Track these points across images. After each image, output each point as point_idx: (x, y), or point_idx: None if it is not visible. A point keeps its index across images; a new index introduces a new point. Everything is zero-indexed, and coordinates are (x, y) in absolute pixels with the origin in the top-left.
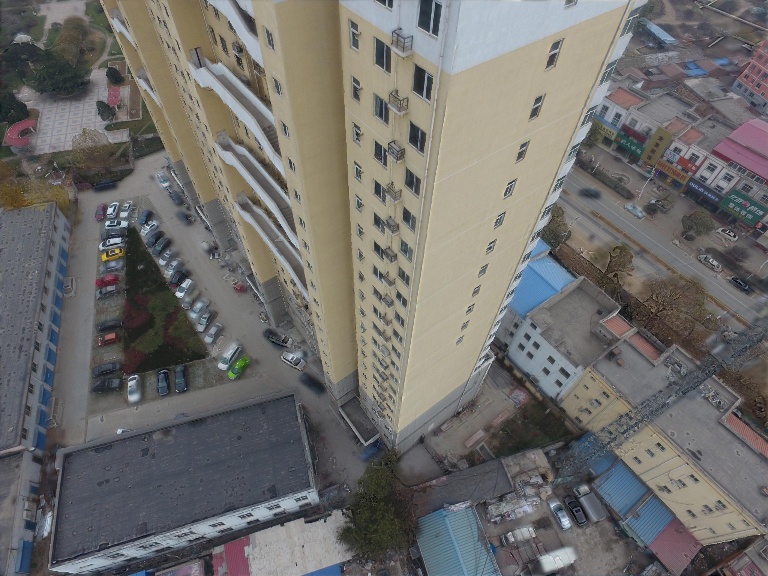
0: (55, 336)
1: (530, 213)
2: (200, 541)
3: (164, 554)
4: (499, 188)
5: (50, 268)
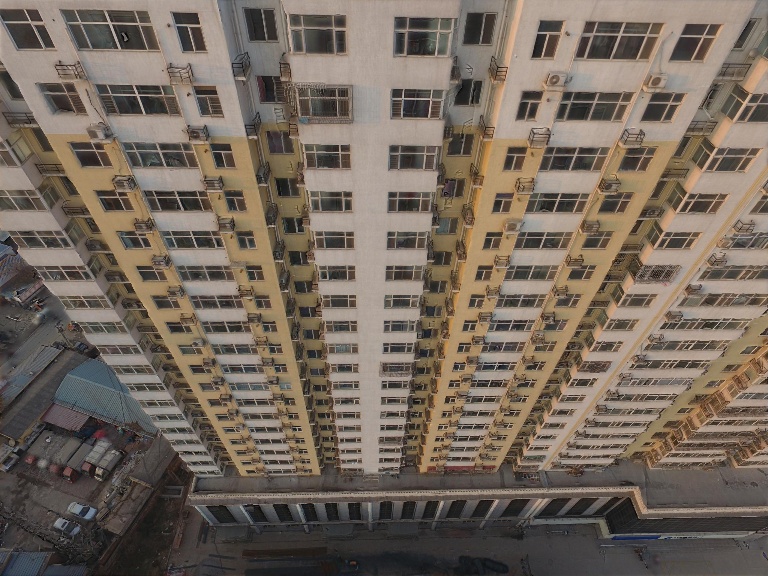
0: None
1: None
2: None
3: None
4: None
5: None
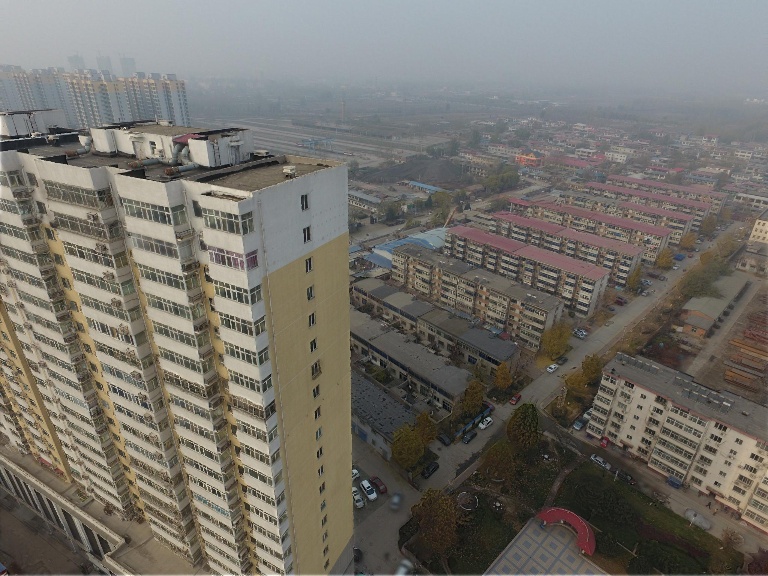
0: None
1: None
2: None
3: None
4: None
5: None
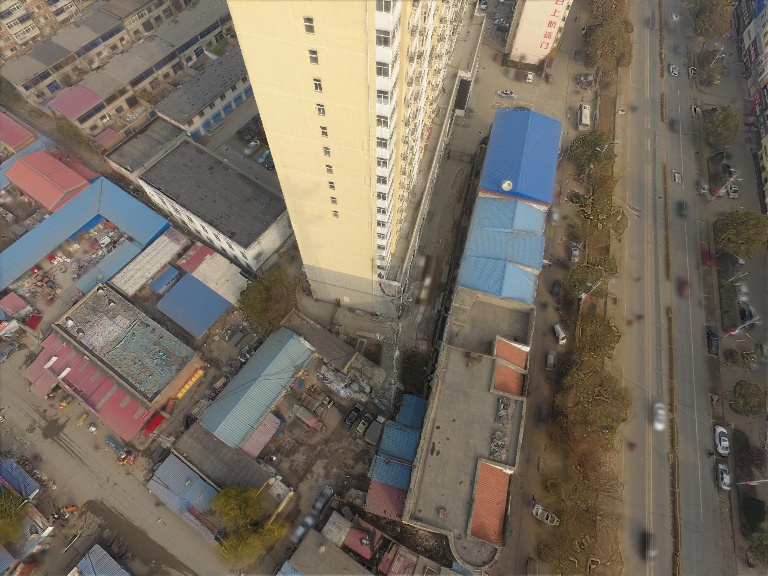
0: (250, 93)
1: (357, 129)
2: (201, 237)
3: (185, 227)
4: (304, 76)
5: None
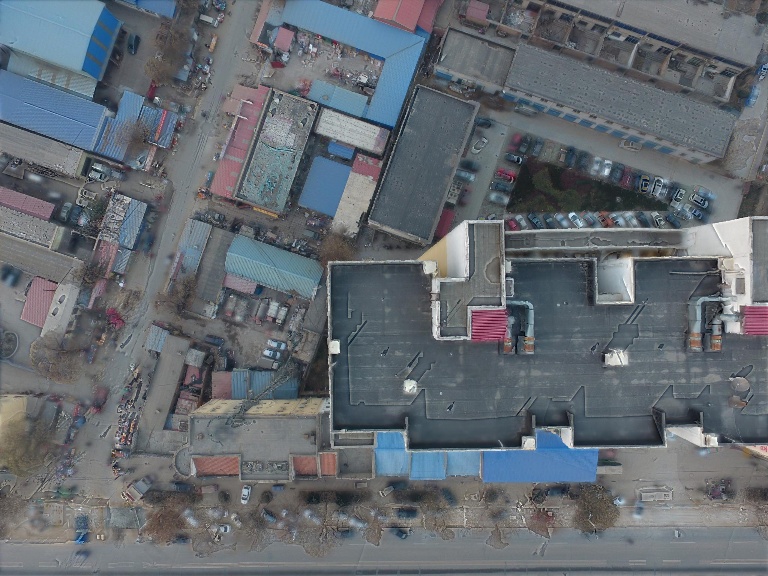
0: (587, 125)
1: None
2: None
3: None
4: None
5: (649, 136)
